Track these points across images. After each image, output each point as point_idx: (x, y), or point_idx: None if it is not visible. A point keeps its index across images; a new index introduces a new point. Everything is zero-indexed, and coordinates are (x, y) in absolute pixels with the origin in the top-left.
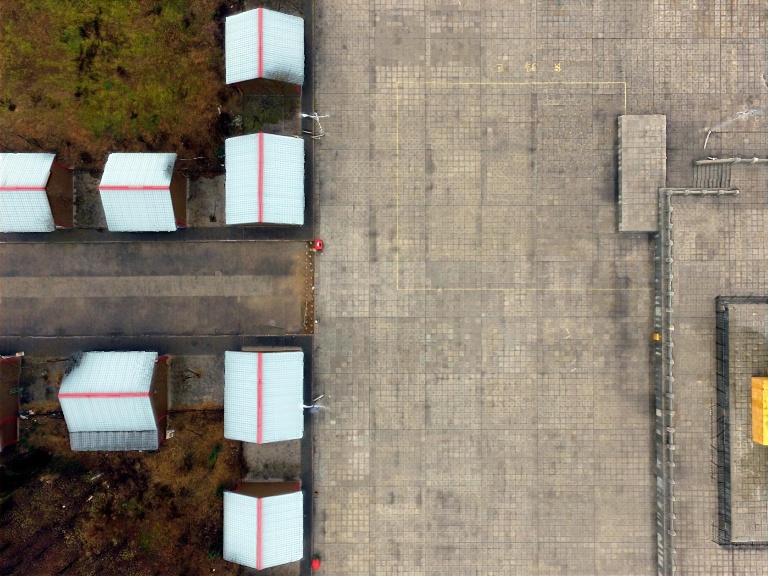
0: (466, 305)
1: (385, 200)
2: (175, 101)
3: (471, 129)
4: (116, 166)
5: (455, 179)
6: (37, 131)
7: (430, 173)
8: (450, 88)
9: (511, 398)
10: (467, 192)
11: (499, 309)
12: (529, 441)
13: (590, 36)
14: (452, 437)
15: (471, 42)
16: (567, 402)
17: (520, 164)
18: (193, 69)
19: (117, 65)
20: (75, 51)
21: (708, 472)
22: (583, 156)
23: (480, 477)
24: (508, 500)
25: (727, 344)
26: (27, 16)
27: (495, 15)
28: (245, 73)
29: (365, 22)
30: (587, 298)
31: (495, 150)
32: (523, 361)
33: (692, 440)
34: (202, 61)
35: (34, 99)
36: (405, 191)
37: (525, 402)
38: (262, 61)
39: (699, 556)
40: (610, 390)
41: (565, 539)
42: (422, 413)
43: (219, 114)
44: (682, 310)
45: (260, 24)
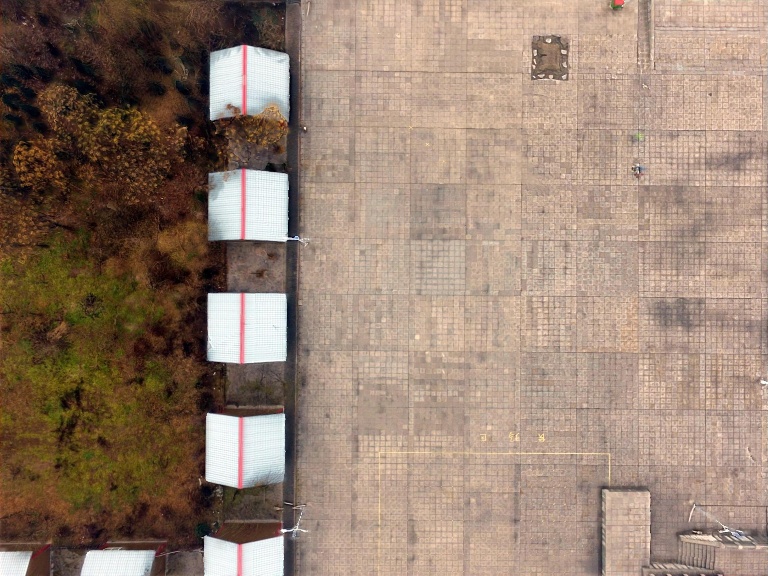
0: None
1: (366, 571)
2: (155, 472)
3: (454, 499)
4: (93, 570)
5: (437, 550)
6: (15, 504)
7: (412, 544)
8: (433, 458)
9: None
10: (449, 564)
11: None
12: None
13: (574, 406)
14: None
15: (455, 411)
16: None
17: (503, 535)
18: (174, 439)
19: (98, 435)
20: (55, 421)
21: None
22: (567, 528)
23: None
24: None
25: None
26: (8, 387)
27: (479, 384)
28: (224, 478)
29: (348, 391)
30: None
31: (478, 521)
32: None
33: None
34: (183, 430)
35: (13, 471)
36: (387, 562)
37: None
38: (241, 471)
39: None
40: None
41: None
42: None
43: (200, 485)
44: None
45: (240, 434)
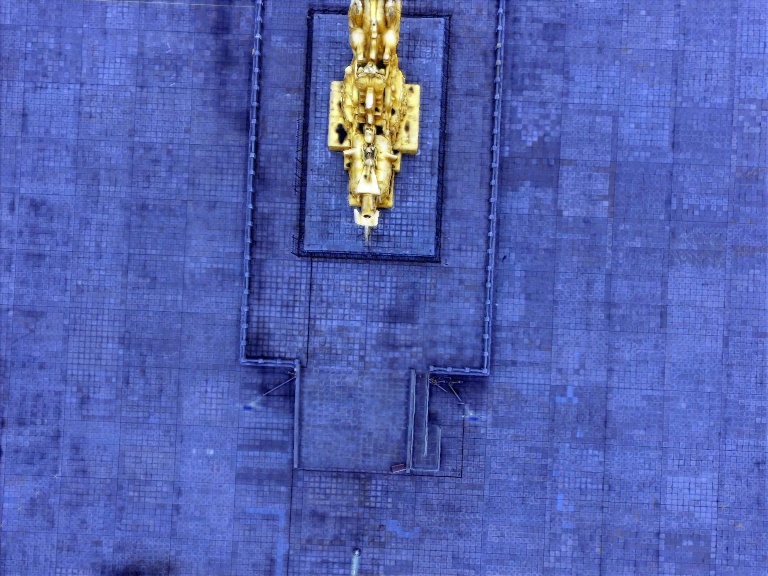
0: (68, 15)
1: None
2: None
3: None
4: None
5: None
6: None
7: None
8: None
9: (109, 110)
10: None
11: (101, 20)
12: (125, 153)
13: None
14: (48, 146)
15: None
16: (164, 116)
17: None
18: None
19: None
20: None
21: (292, 185)
22: None
23: (74, 187)
24: (101, 211)
25: (311, 54)
26: None
27: None
28: None
29: None
30: (189, 13)
31: None
32: (123, 74)
33: (277, 152)
34: None
35: None
36: None
37: (123, 114)
38: None
39: (278, 267)
40: (208, 106)
41: (155, 252)
42: (19, 120)
43: None
44: (274, 22)
45: None
